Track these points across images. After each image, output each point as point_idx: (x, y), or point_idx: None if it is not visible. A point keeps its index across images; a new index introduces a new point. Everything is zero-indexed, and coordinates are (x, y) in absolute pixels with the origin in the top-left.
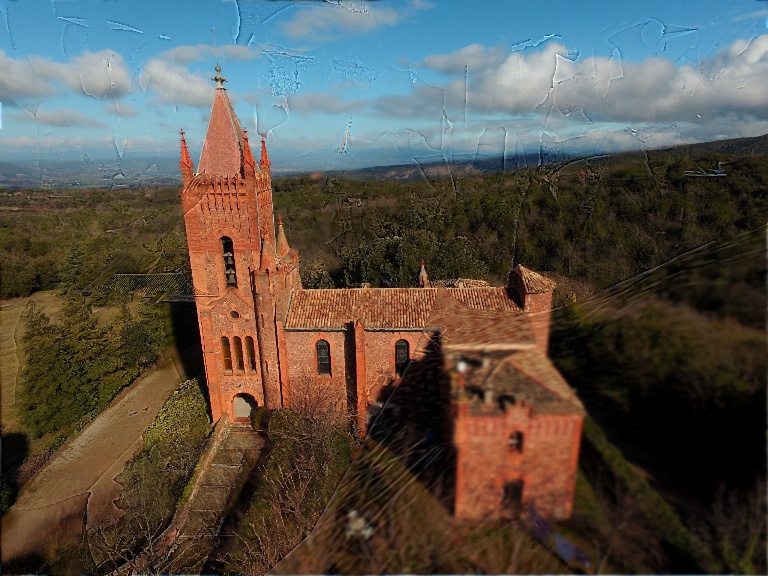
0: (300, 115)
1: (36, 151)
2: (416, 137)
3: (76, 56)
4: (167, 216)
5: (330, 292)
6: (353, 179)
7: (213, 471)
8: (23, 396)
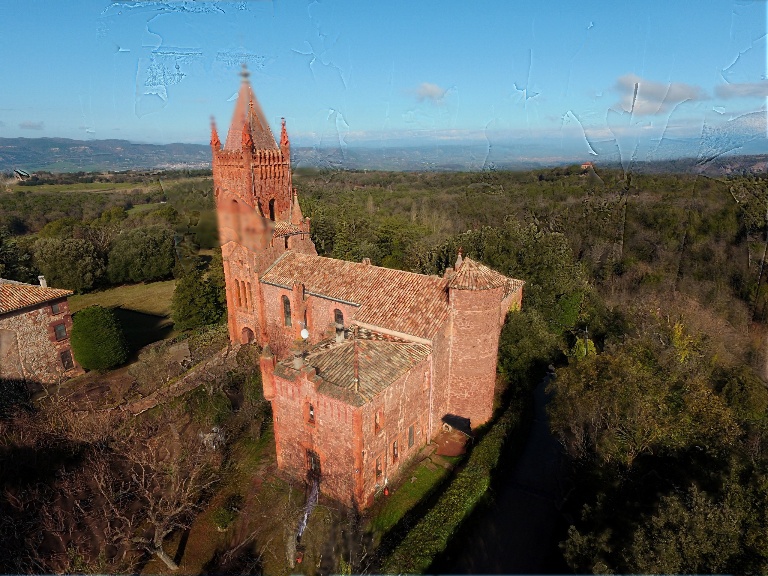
0: (195, 100)
1: None
2: (586, 119)
3: None
4: None
5: (310, 258)
6: (514, 165)
7: (204, 376)
8: None
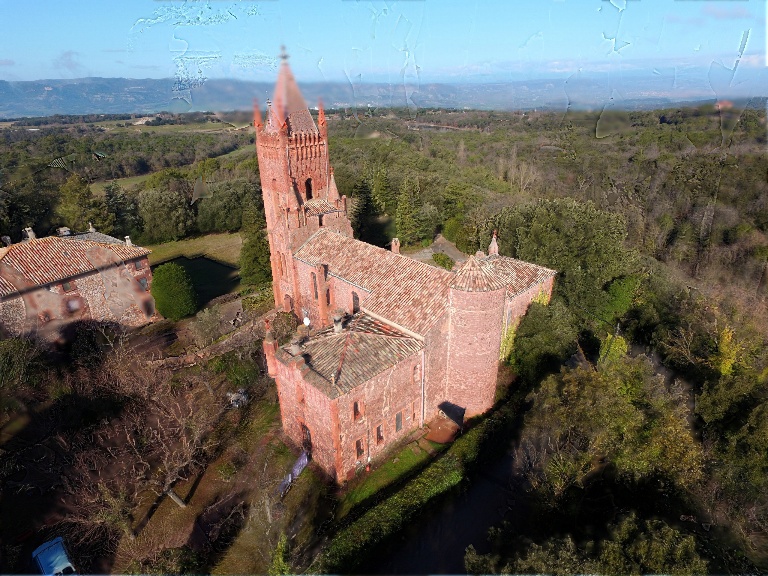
0: (219, 100)
1: (363, 88)
2: (684, 74)
3: (347, 18)
4: (1, 174)
5: (339, 237)
6: None
7: (249, 336)
8: (240, 258)
